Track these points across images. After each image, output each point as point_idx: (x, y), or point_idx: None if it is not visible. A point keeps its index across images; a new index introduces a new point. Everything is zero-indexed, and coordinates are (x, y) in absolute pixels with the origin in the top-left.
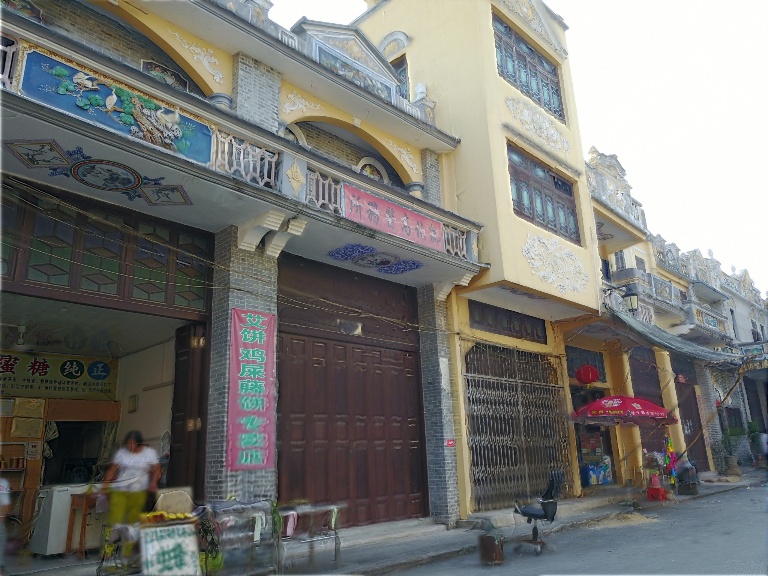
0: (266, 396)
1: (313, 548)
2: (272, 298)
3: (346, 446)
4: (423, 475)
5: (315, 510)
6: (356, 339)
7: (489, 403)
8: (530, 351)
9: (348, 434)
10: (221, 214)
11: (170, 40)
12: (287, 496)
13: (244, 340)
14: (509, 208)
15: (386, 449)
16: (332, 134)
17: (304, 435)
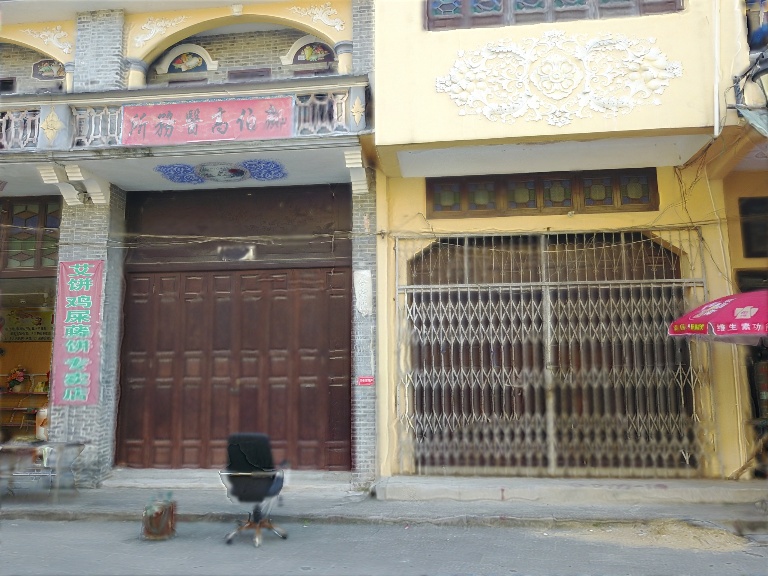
0: (91, 338)
1: (22, 482)
2: (101, 244)
3: (226, 383)
4: (349, 419)
5: (27, 448)
6: (242, 265)
7: (459, 323)
8: (583, 231)
9: (229, 370)
10: (34, 181)
11: (23, 39)
12: (149, 430)
13: (71, 289)
14: (411, 26)
15: (287, 387)
16: (253, 32)
17: (172, 372)
